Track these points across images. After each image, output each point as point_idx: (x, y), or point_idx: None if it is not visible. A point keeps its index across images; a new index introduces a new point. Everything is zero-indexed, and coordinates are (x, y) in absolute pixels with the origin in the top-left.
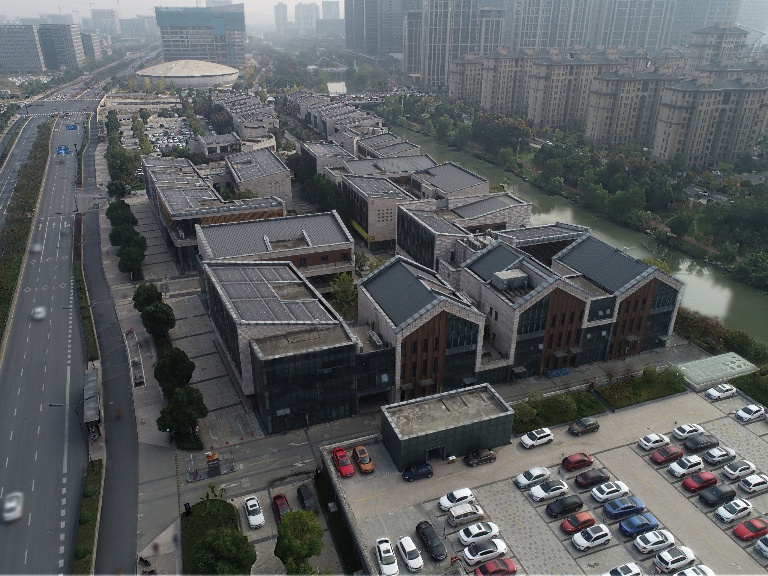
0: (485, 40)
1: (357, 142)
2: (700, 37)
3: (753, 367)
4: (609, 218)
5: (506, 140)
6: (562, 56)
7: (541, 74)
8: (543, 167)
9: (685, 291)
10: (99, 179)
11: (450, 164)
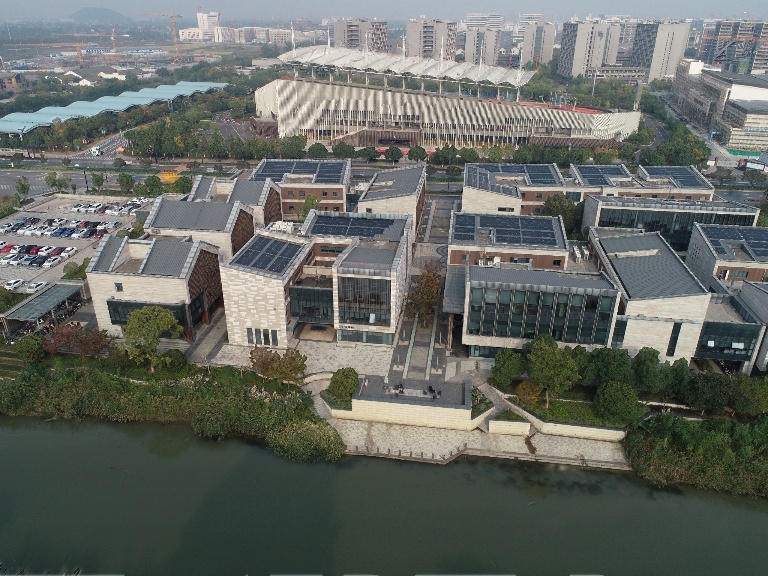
0: None
1: None
2: None
3: (14, 316)
4: None
5: None
6: None
7: None
8: None
9: (143, 483)
10: None
11: None
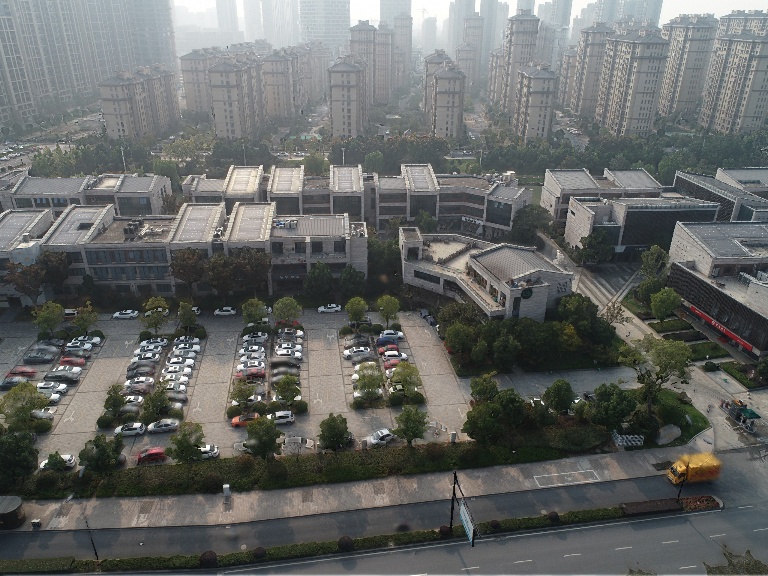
0: (3, 50)
1: (562, 191)
2: (364, 34)
3: None
4: (666, 184)
5: (435, 158)
6: (353, 60)
7: (353, 82)
8: (517, 170)
9: None
10: (609, 474)
11: (724, 169)
